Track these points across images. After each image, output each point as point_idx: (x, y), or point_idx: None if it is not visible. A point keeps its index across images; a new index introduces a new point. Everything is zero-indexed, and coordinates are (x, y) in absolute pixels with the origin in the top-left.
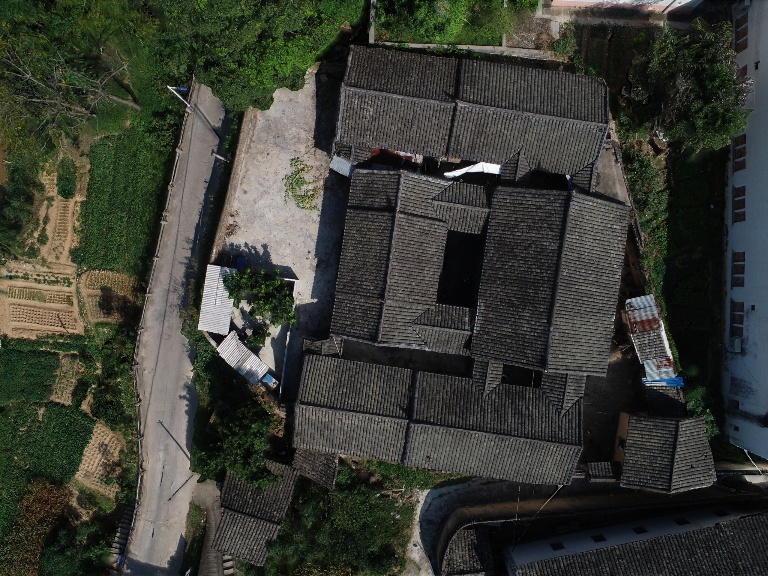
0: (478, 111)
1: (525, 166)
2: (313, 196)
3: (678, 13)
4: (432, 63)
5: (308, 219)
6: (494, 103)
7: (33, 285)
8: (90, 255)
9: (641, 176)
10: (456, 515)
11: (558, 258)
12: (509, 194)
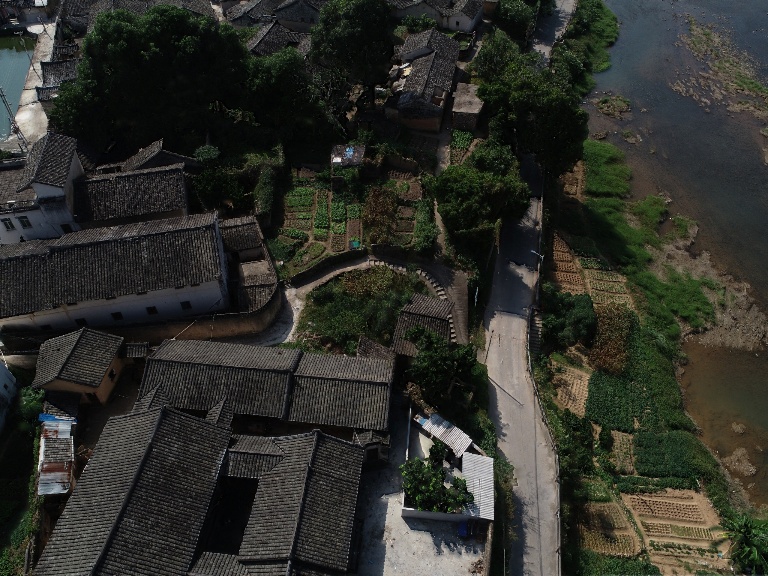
0: None
1: None
2: None
3: None
4: None
5: None
6: None
7: (690, 543)
8: (639, 573)
9: None
10: (263, 323)
11: (126, 508)
12: None
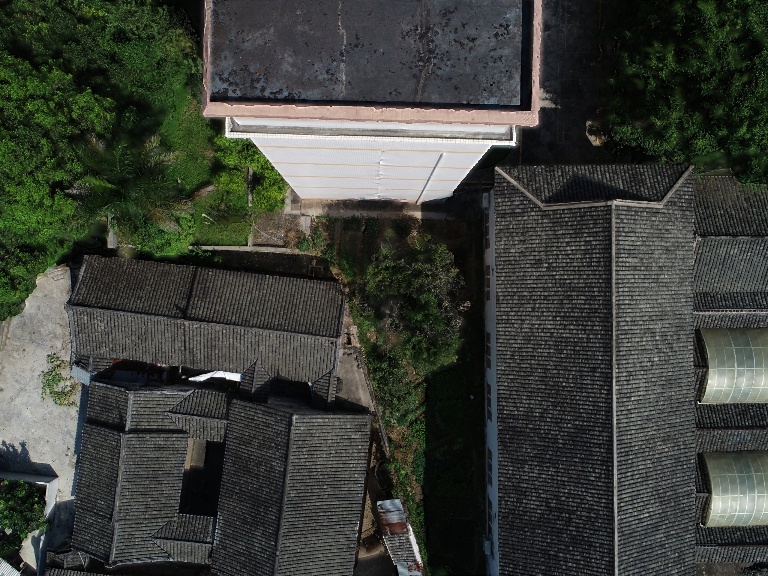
0: (207, 327)
1: (263, 375)
2: (70, 392)
3: (432, 204)
4: (168, 272)
5: (66, 415)
6: (223, 318)
7: None
8: None
9: (389, 376)
10: None
11: (283, 481)
12: (243, 408)
